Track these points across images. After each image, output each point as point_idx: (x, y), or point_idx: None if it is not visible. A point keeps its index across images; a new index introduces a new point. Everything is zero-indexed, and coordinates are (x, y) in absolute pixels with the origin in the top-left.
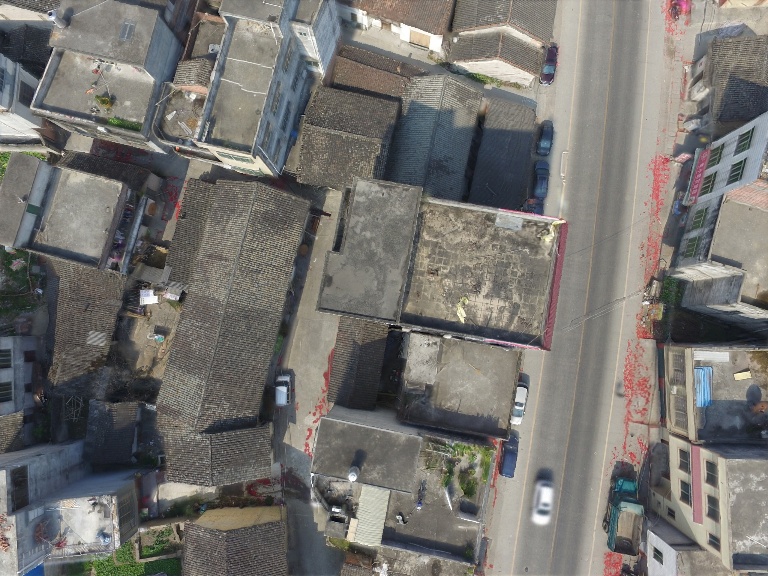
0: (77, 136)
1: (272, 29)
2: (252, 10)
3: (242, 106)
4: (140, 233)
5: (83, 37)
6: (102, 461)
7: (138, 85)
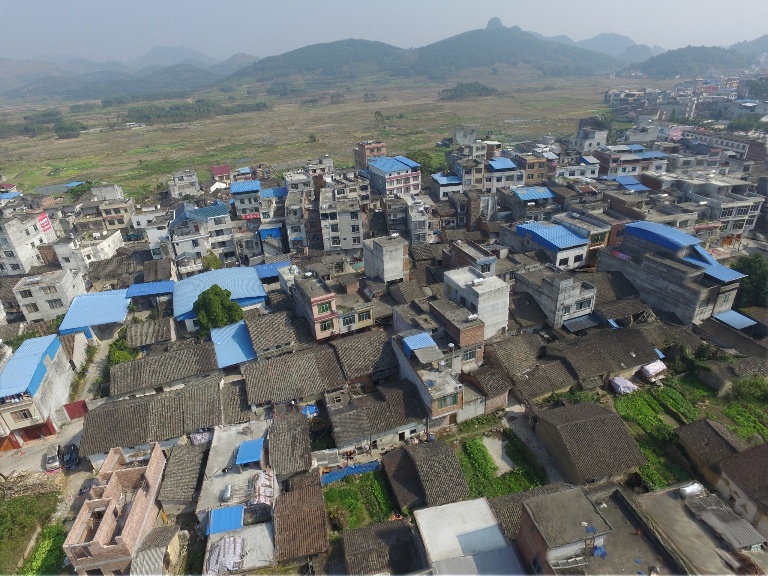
0: None
1: None
2: None
3: None
4: None
5: None
6: None
7: None
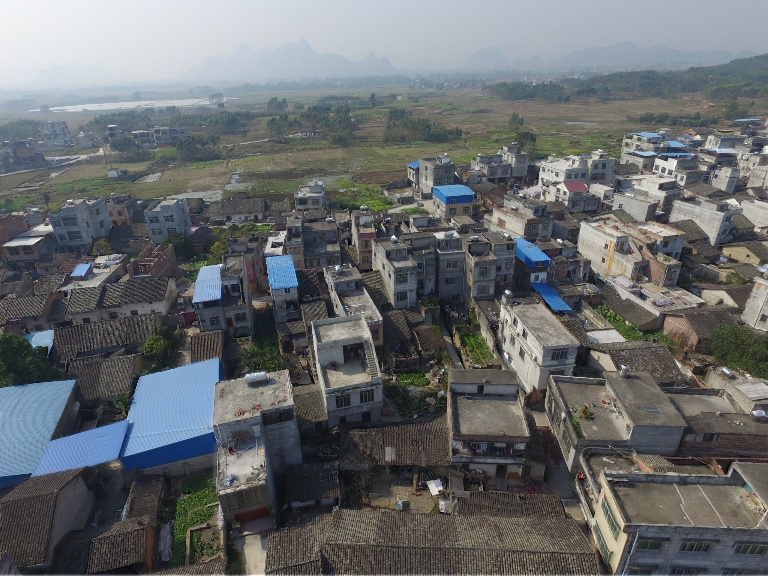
0: (542, 416)
1: (766, 514)
2: (764, 489)
3: (665, 508)
4: (489, 470)
5: (625, 387)
6: (288, 477)
7: (615, 432)
